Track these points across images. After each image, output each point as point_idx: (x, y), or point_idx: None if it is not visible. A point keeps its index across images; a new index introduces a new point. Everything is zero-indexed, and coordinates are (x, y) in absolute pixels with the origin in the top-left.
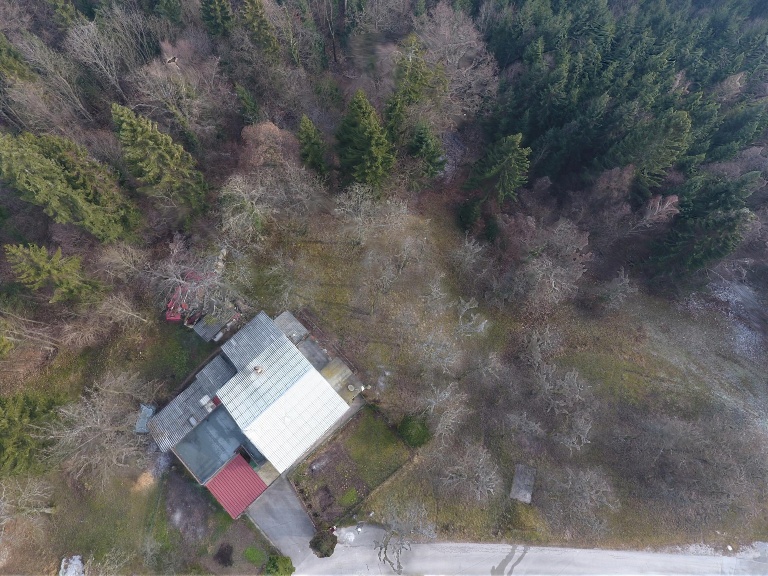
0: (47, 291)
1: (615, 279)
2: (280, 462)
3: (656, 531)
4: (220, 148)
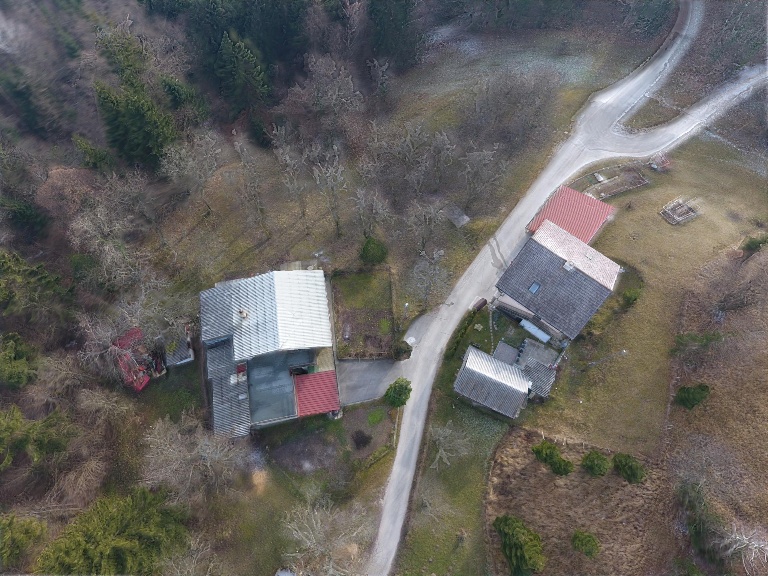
0: (21, 465)
1: (371, 71)
2: (323, 340)
3: (532, 161)
4: (29, 255)
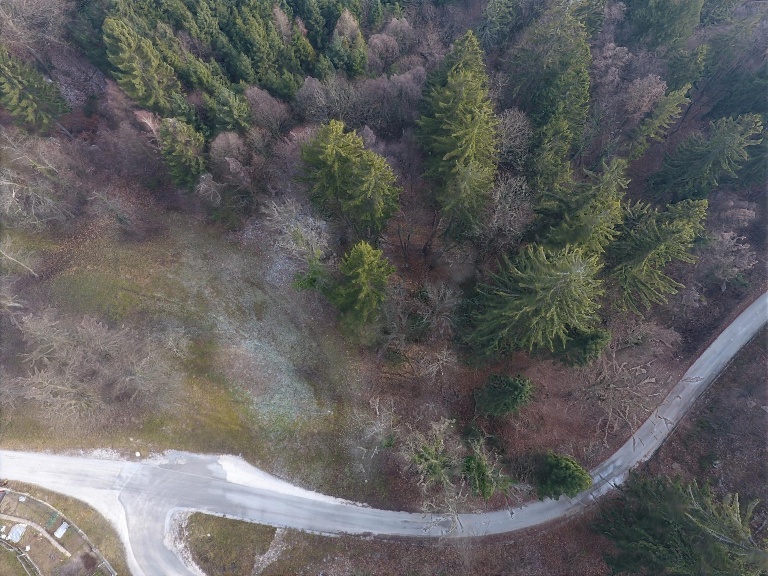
0: None
1: None
2: None
3: (64, 435)
4: None
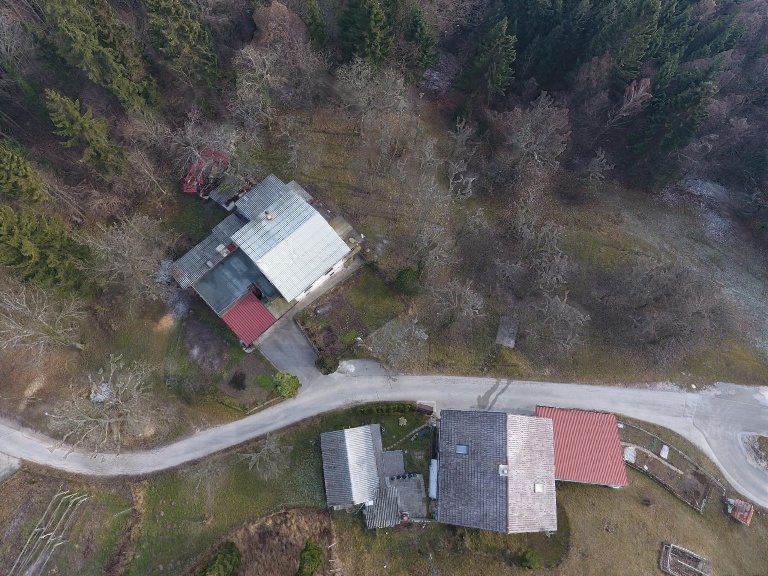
0: (77, 156)
1: None
2: (288, 292)
3: (627, 370)
4: (232, 45)
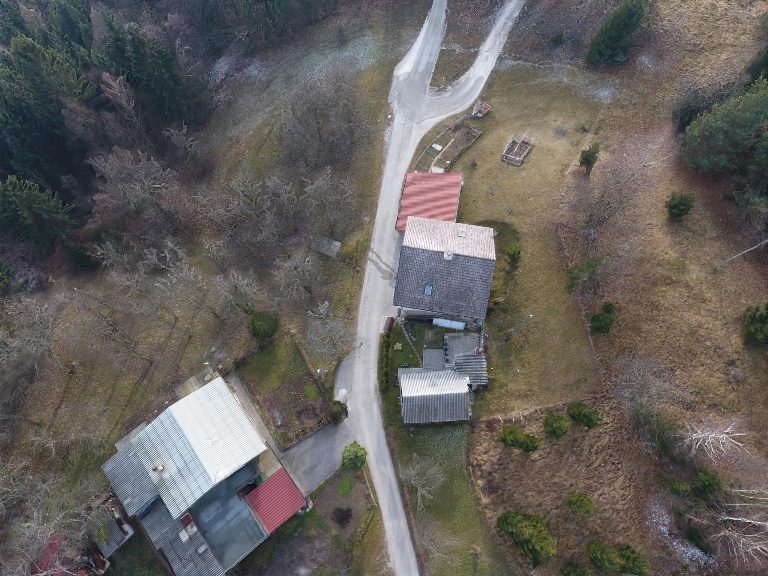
0: None
1: None
2: (255, 448)
3: (372, 159)
4: None
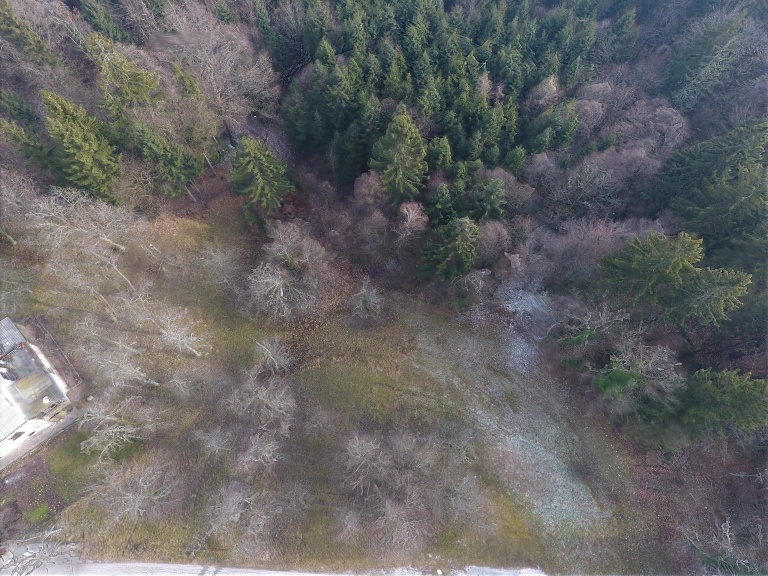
0: None
1: None
2: None
3: (362, 553)
4: None
